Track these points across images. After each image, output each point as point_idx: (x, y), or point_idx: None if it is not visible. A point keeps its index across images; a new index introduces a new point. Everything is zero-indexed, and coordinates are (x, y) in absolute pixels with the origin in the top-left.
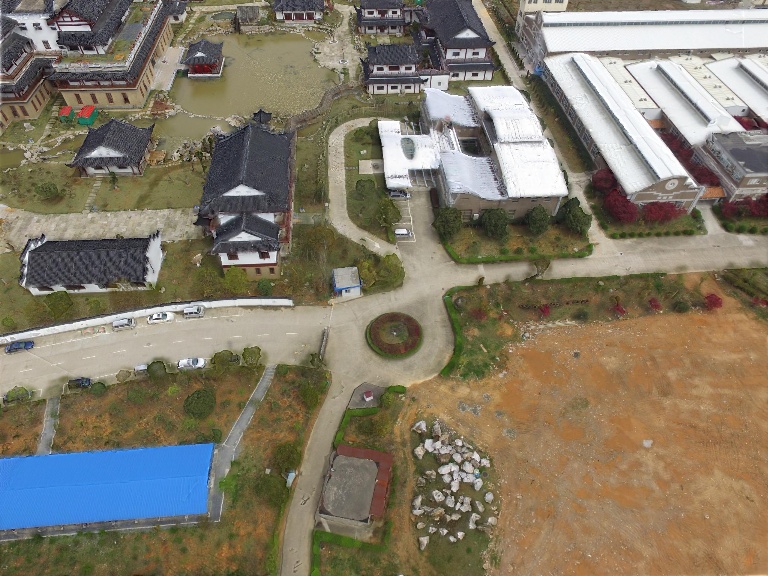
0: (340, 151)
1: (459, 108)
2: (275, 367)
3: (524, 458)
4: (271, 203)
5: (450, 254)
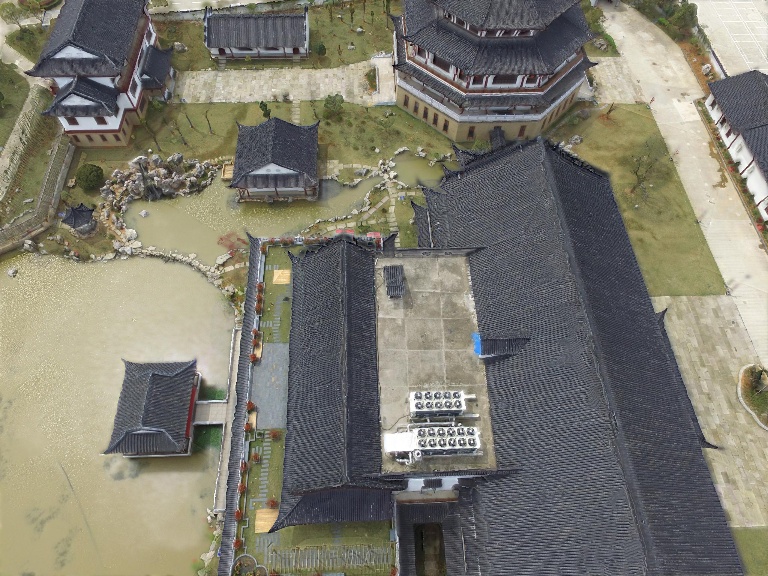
0: None
1: None
2: None
3: None
4: None
5: None
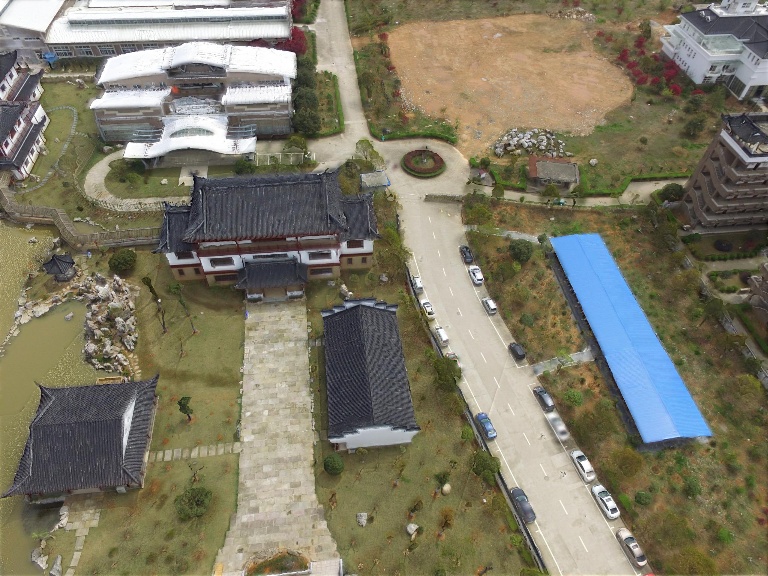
0: (154, 201)
1: (133, 95)
2: (466, 225)
3: (506, 118)
4: (331, 178)
5: (335, 133)
